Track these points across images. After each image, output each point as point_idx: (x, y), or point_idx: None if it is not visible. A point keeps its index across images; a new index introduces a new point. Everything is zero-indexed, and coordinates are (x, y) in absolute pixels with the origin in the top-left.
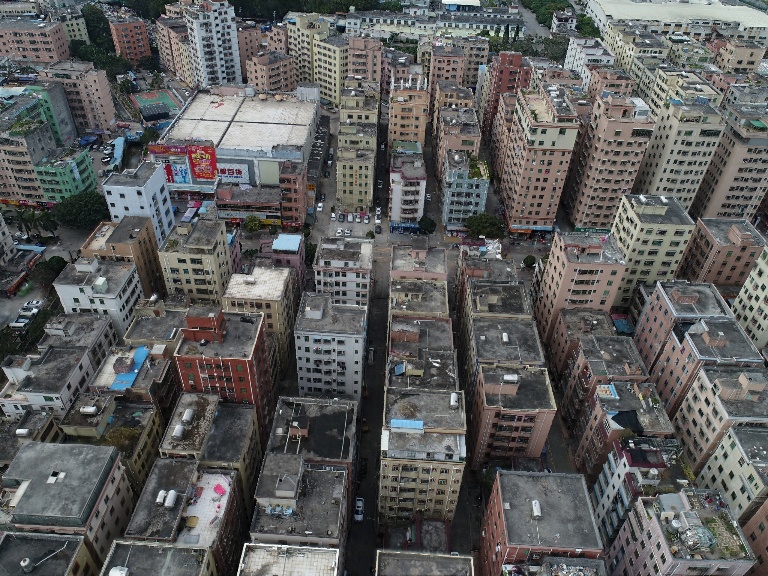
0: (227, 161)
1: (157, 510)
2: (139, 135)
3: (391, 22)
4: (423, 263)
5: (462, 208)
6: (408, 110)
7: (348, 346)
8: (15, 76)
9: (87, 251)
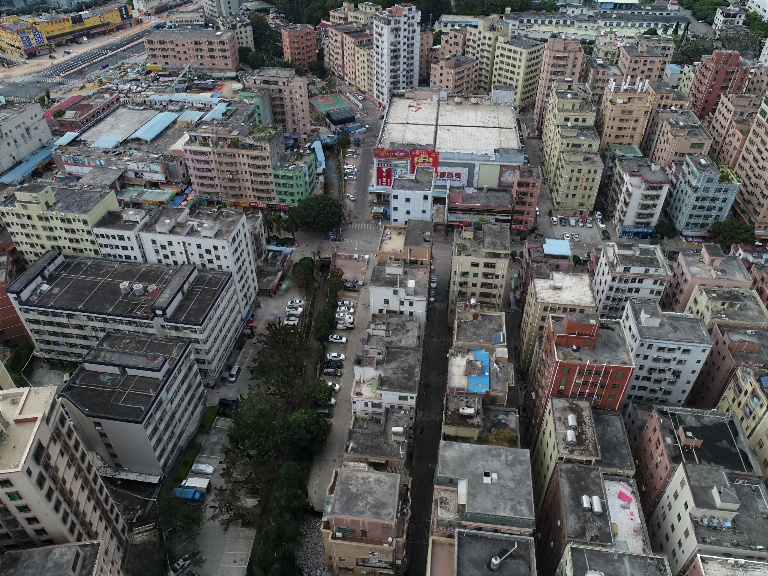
0: (448, 165)
1: (585, 515)
2: (332, 139)
3: (549, 22)
4: (724, 271)
5: (704, 213)
6: (628, 112)
7: (692, 355)
8: (194, 83)
9: (383, 254)
